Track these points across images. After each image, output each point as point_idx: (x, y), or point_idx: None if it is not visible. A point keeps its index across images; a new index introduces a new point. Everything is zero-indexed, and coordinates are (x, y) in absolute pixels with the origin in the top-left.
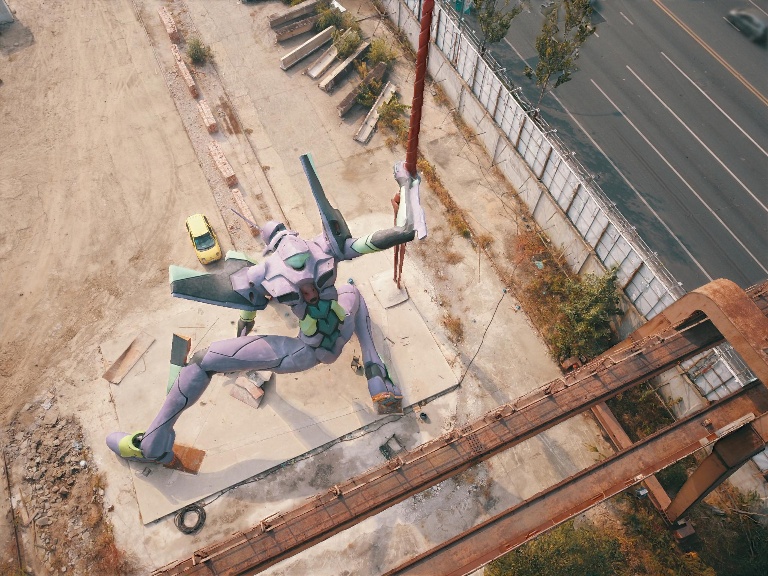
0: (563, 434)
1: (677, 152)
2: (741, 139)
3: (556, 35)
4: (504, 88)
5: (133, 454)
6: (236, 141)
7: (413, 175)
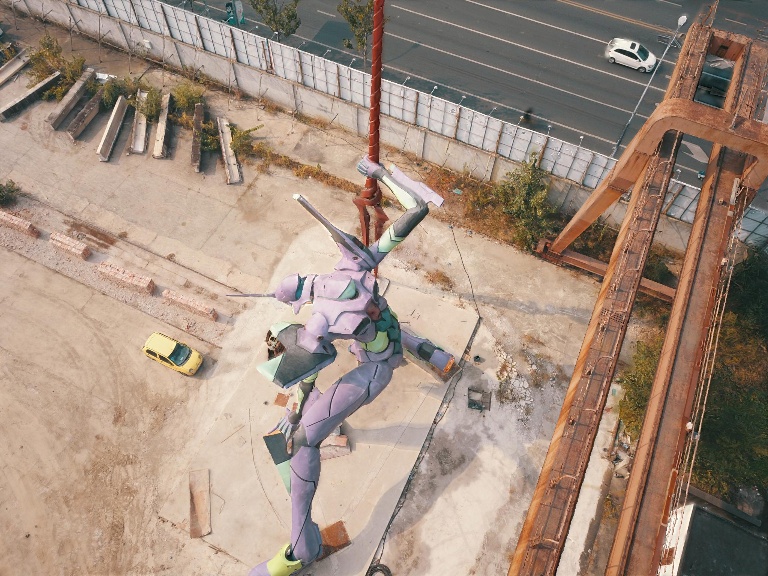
0: (573, 299)
1: (478, 51)
2: (510, 19)
3: (319, 7)
4: (342, 66)
5: (293, 571)
6: (119, 251)
7: (379, 164)
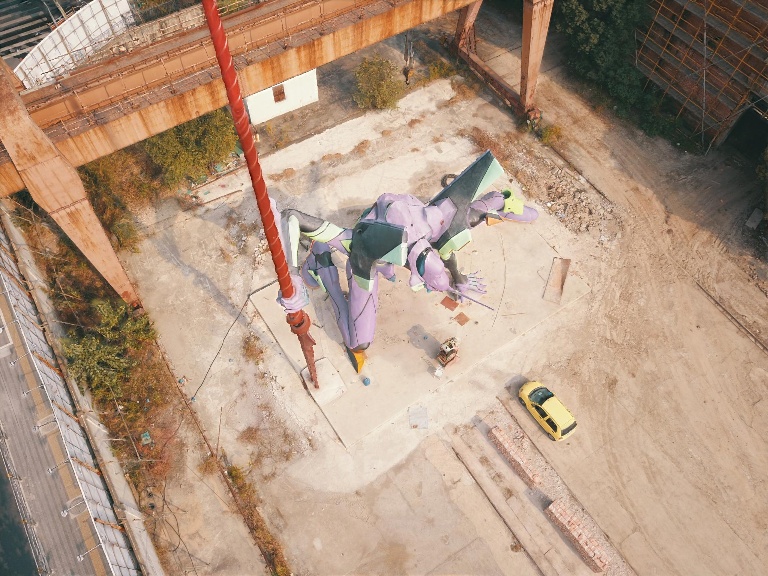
0: (159, 268)
1: None
2: None
3: None
4: None
5: None
6: None
7: None
